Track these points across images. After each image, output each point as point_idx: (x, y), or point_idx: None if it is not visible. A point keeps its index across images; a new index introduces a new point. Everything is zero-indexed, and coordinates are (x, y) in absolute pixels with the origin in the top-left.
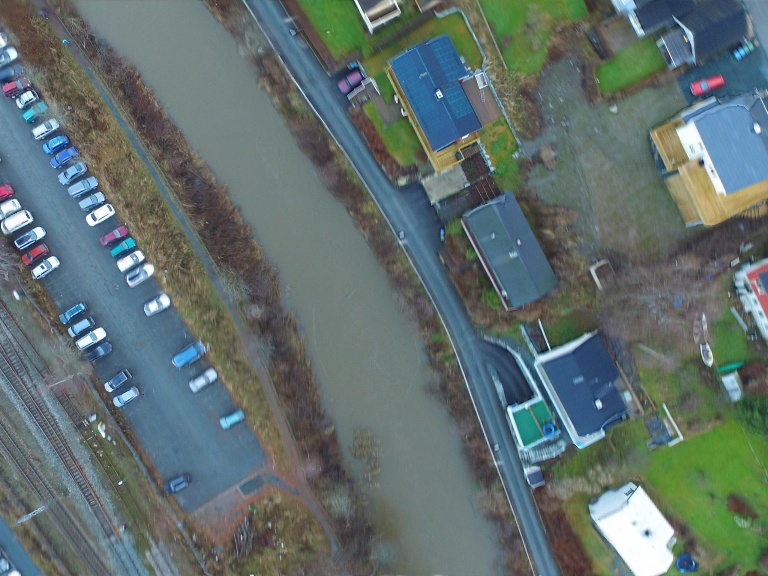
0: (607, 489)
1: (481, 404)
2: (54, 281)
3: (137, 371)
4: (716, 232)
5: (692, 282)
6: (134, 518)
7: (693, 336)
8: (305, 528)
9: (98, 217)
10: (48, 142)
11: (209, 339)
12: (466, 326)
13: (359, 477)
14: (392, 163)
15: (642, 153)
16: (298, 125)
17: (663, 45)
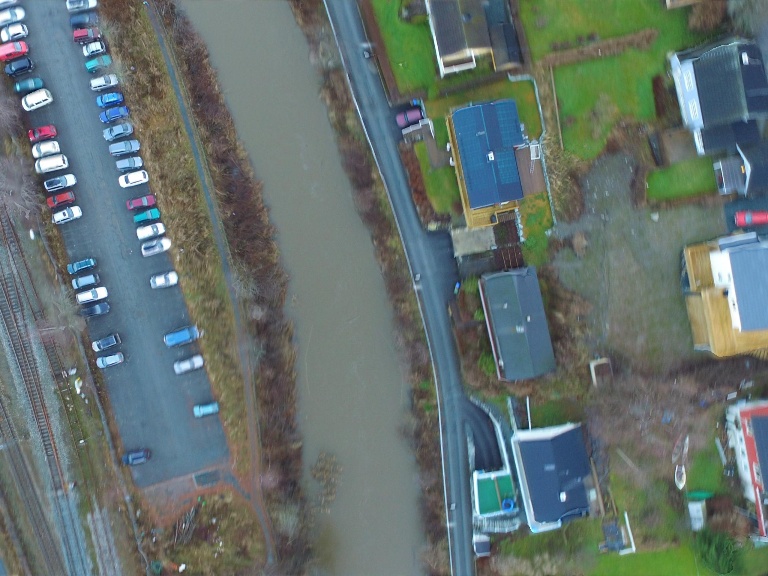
0: None
1: (449, 461)
2: (72, 230)
3: (127, 338)
4: (721, 362)
5: (685, 403)
6: (86, 478)
7: (672, 455)
8: (247, 533)
9: (131, 180)
10: (103, 95)
11: (205, 326)
12: (456, 382)
13: (313, 498)
14: (427, 206)
15: (671, 266)
16: (347, 144)
17: (719, 169)
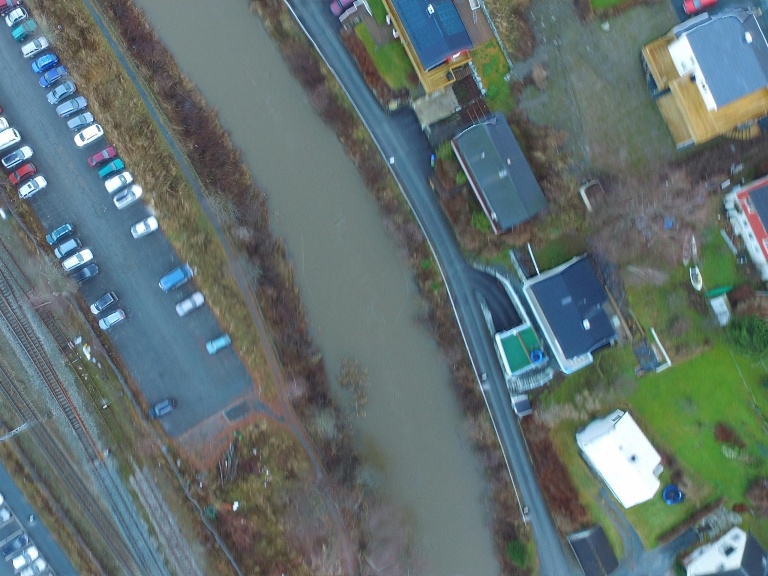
0: (594, 418)
1: (469, 333)
2: (41, 202)
3: (123, 294)
4: (707, 151)
5: (682, 203)
6: (118, 442)
7: (682, 259)
8: (290, 455)
9: (86, 137)
10: (37, 60)
11: (196, 263)
12: (455, 254)
13: (346, 406)
14: (383, 86)
15: (634, 72)
16: (289, 49)
17: None
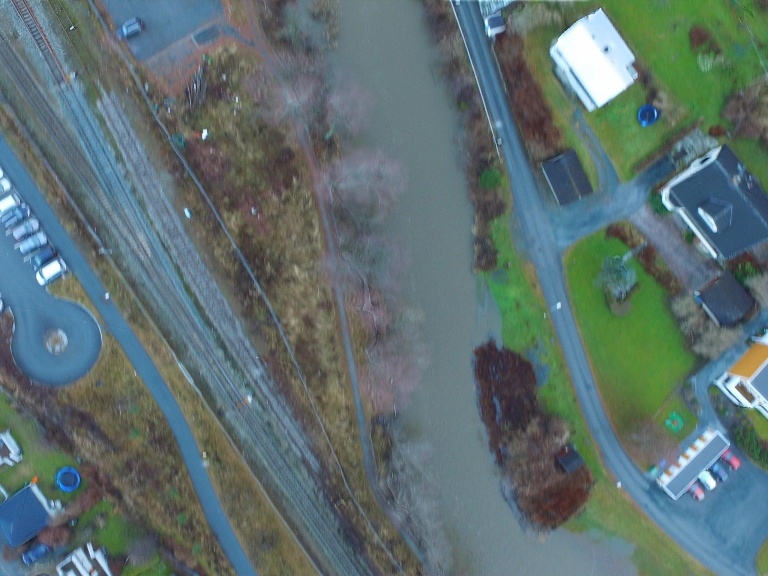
0: None
1: None
2: None
3: None
4: None
5: None
6: (85, 65)
7: None
8: (260, 81)
9: None
10: None
11: None
12: None
13: (317, 37)
14: None
15: None
16: None
17: None
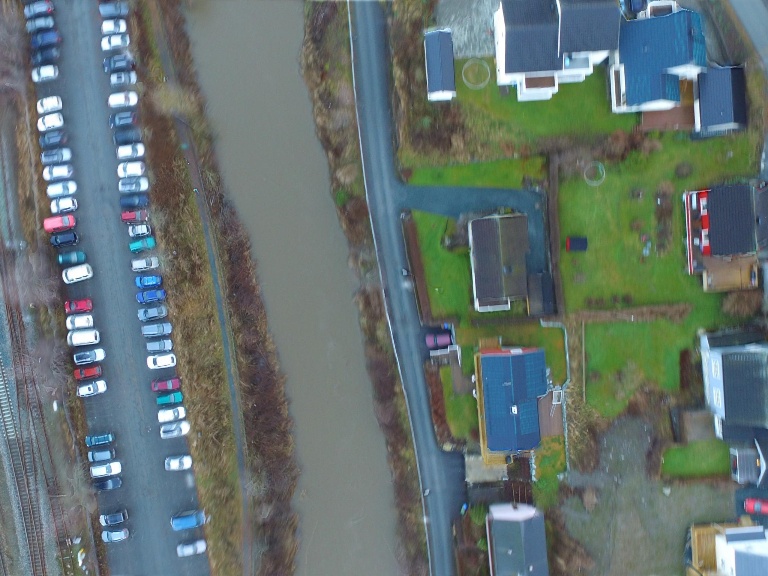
0: None
1: None
2: (94, 402)
3: (135, 514)
4: None
5: None
6: None
7: None
8: None
9: (159, 364)
10: (142, 277)
11: (213, 512)
12: None
13: None
14: (445, 429)
15: (676, 538)
16: (374, 351)
17: (735, 455)
